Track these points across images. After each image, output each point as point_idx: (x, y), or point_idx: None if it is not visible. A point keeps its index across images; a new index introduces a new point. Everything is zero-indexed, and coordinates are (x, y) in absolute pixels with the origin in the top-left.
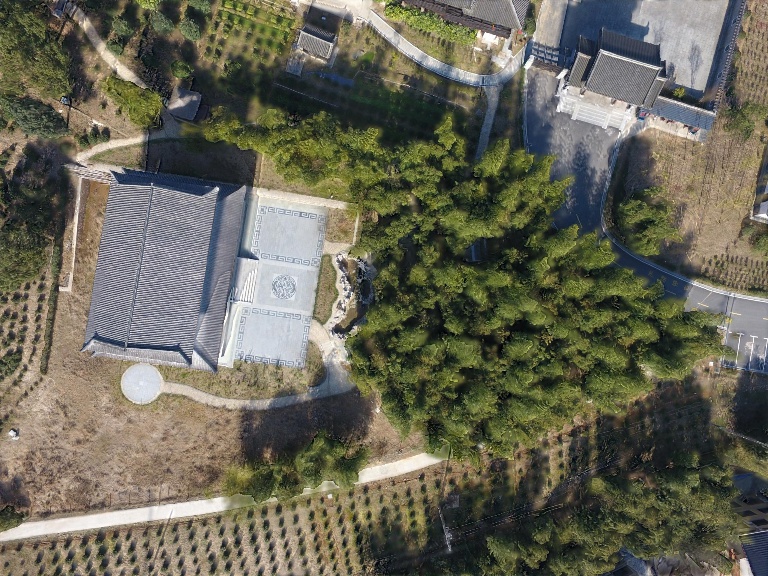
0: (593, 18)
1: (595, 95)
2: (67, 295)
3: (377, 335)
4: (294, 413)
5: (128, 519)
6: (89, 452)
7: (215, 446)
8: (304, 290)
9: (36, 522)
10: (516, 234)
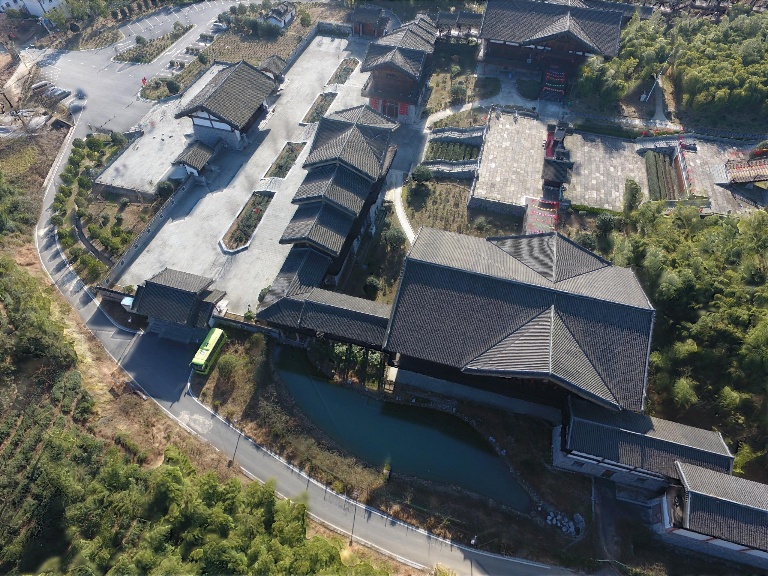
0: None
1: None
2: None
3: None
4: None
5: None
6: None
7: None
8: None
9: None
10: None
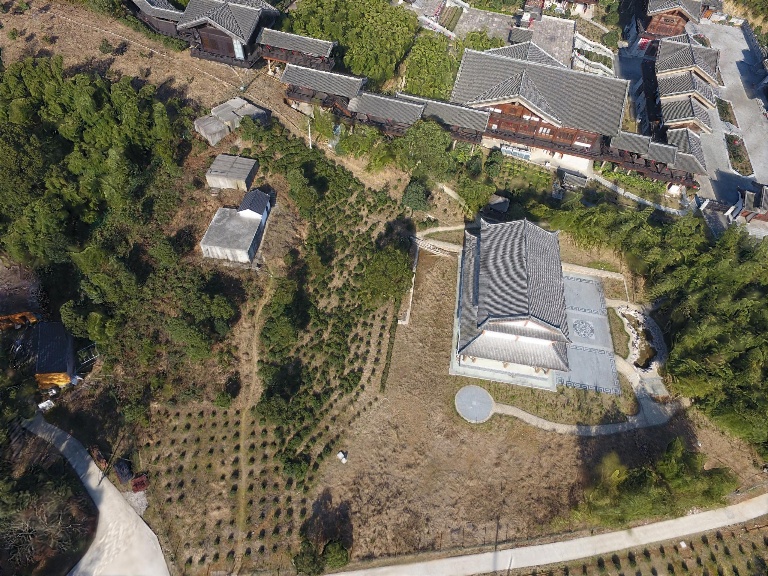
0: (730, 188)
1: (757, 224)
2: (403, 327)
3: (694, 350)
4: (622, 440)
5: (461, 569)
6: (419, 479)
7: (551, 474)
8: (600, 332)
9: (353, 571)
10: (762, 290)
